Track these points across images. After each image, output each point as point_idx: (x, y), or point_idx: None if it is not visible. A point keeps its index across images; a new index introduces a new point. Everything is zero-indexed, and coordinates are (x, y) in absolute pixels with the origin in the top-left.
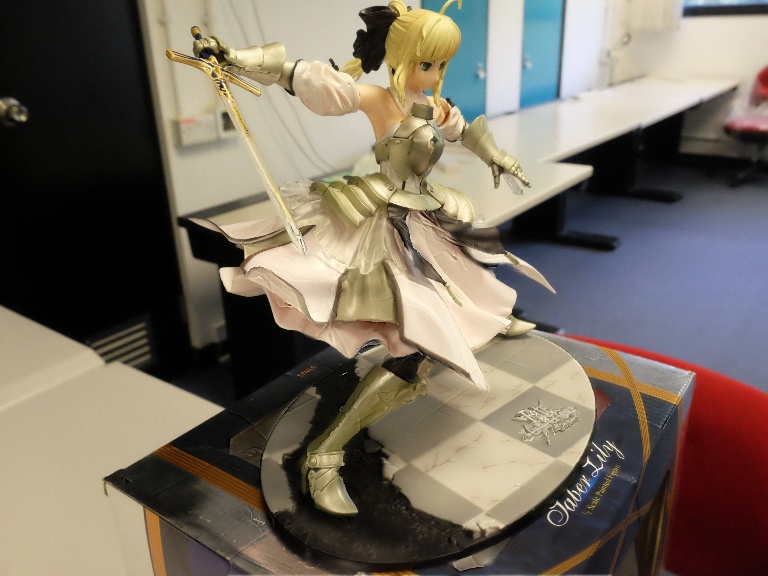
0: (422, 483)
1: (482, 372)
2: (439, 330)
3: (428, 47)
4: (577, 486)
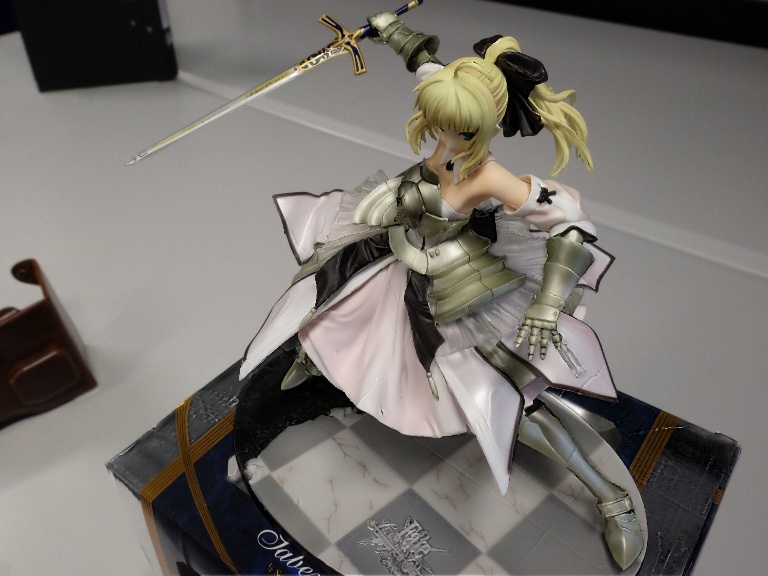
0: (318, 434)
1: (512, 501)
2: (272, 321)
3: (422, 105)
4: (308, 568)
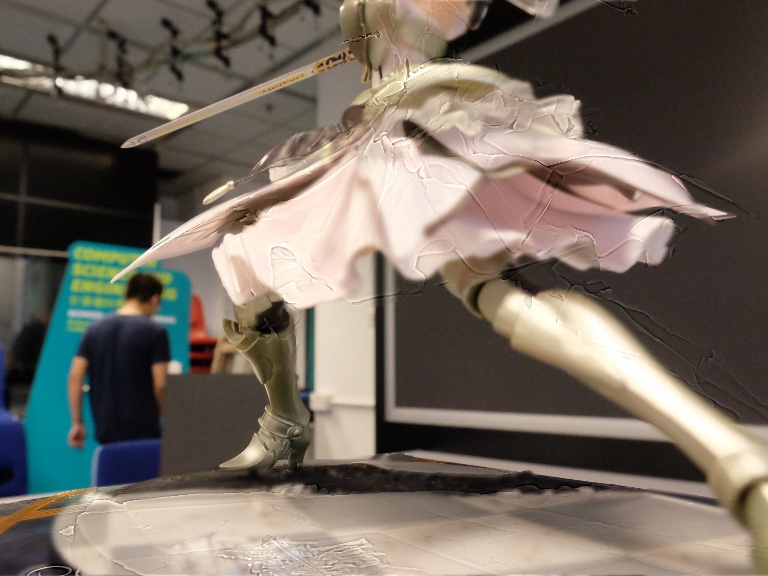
0: (243, 499)
1: (601, 545)
2: None
3: None
4: None
